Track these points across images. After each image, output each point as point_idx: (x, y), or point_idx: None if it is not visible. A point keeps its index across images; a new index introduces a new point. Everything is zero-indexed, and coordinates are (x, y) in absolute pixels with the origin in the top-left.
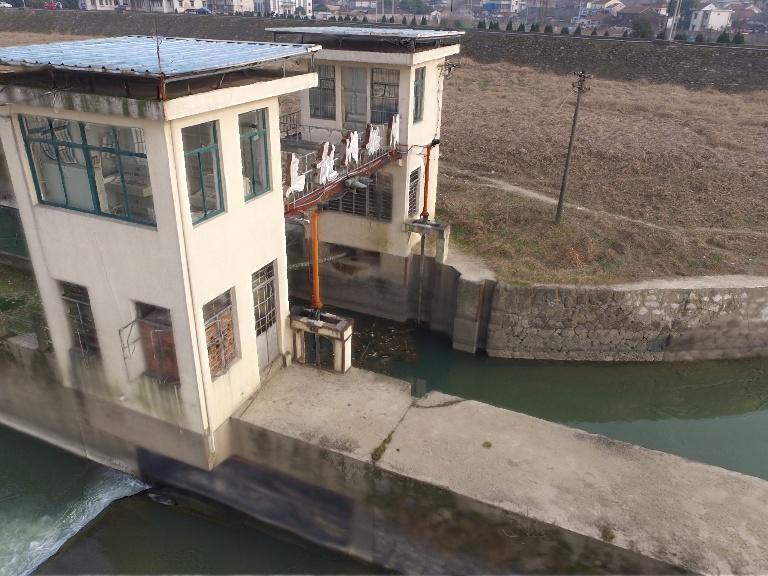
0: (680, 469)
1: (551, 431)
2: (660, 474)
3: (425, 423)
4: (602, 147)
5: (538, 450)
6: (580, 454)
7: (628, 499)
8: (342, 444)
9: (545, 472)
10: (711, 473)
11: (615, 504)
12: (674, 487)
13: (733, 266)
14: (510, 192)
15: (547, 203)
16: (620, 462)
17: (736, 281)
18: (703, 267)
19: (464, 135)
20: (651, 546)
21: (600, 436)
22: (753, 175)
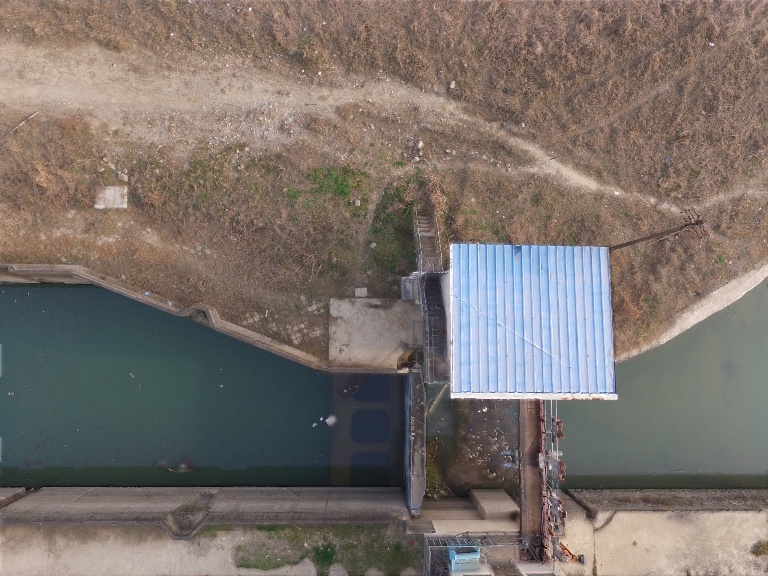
0: (710, 520)
1: (657, 519)
2: (703, 528)
3: (605, 541)
4: (616, 3)
5: (655, 536)
6: (672, 530)
7: (693, 550)
8: (578, 574)
9: (661, 549)
10: (721, 517)
11: (689, 555)
12: (709, 533)
13: (730, 268)
14: (555, 184)
15: (590, 194)
16: (687, 527)
17: (732, 293)
18: (711, 277)
19: (459, 8)
20: (703, 571)
21: (677, 512)
22: (756, 43)
